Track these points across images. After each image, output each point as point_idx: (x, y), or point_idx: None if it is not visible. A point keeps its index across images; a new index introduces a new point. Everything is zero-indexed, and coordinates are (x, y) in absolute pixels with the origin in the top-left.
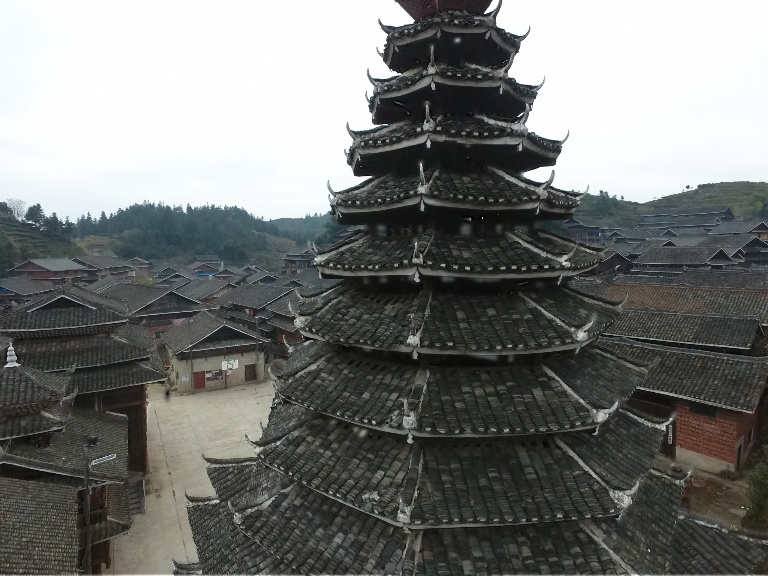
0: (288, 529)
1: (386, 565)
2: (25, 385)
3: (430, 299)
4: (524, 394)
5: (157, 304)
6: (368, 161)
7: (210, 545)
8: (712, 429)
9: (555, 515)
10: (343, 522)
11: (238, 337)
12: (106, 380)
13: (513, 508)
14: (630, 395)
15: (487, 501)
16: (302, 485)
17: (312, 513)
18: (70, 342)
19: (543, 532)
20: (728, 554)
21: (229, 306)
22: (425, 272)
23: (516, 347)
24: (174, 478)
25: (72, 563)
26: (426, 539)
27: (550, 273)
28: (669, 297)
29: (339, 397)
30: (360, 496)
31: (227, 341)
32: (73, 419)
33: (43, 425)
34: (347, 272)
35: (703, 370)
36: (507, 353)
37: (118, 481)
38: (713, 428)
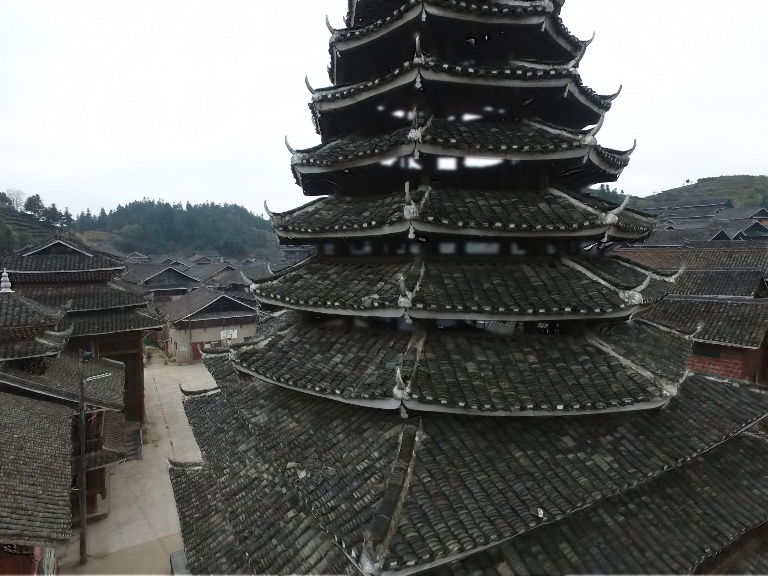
0: (285, 359)
1: (386, 363)
2: (19, 309)
3: (432, 118)
4: (530, 206)
5: (156, 280)
6: (367, 2)
7: (205, 424)
8: (716, 370)
9: (563, 308)
10: (342, 347)
11: (237, 309)
12: (103, 324)
13: (519, 303)
14: (639, 230)
15: (492, 298)
16: (299, 328)
17: (310, 345)
18: (66, 288)
19: (550, 346)
20: (740, 401)
21: (228, 286)
22: (427, 75)
23: (521, 149)
24: (172, 431)
25: (65, 458)
26: (428, 345)
27: (556, 81)
28: (671, 260)
29: (338, 220)
30: (359, 299)
31: (226, 312)
32: (69, 359)
33: (37, 349)
34: (346, 100)
35: (707, 314)
36: (512, 158)
37: (114, 408)
38: (717, 369)
